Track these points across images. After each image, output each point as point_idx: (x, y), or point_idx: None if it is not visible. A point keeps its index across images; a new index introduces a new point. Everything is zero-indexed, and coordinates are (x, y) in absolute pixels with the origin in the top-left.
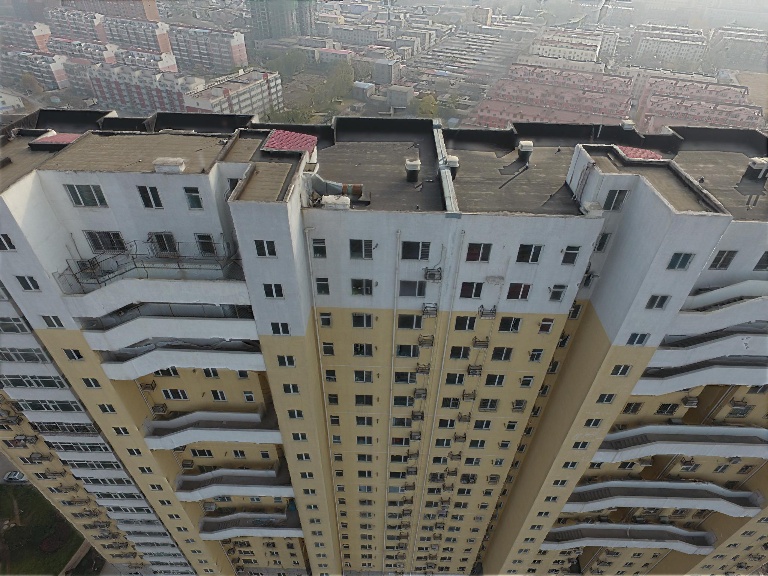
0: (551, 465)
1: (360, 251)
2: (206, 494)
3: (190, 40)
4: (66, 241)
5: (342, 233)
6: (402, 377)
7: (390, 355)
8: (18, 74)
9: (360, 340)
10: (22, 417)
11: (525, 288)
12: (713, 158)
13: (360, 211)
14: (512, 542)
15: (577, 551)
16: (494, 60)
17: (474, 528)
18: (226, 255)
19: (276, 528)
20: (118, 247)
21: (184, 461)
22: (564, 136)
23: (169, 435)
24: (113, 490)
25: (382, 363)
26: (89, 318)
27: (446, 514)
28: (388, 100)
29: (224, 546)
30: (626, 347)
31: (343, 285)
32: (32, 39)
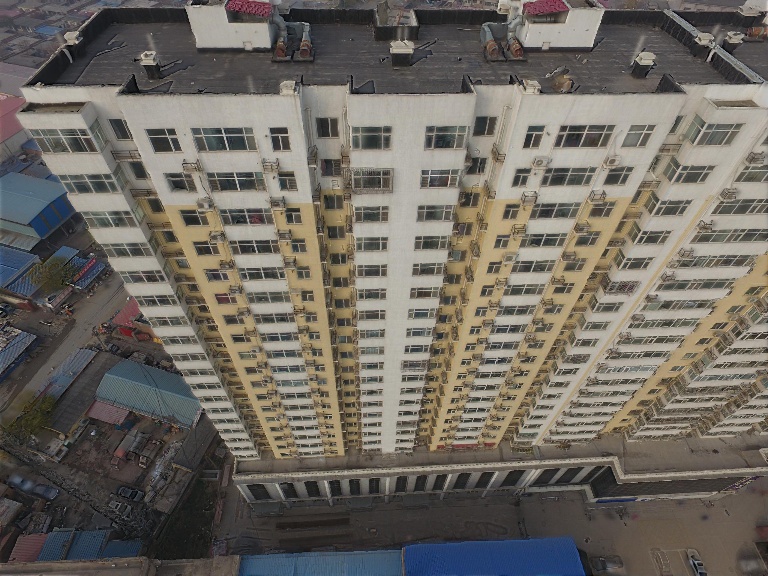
0: None
1: None
2: None
3: None
4: None
5: None
6: None
7: None
8: None
9: None
10: None
11: None
12: (422, 88)
13: None
14: None
15: None
16: None
17: None
18: None
19: None
20: None
21: None
22: None
23: None
24: None
25: None
26: None
27: None
28: None
29: None
30: None
31: None
32: None
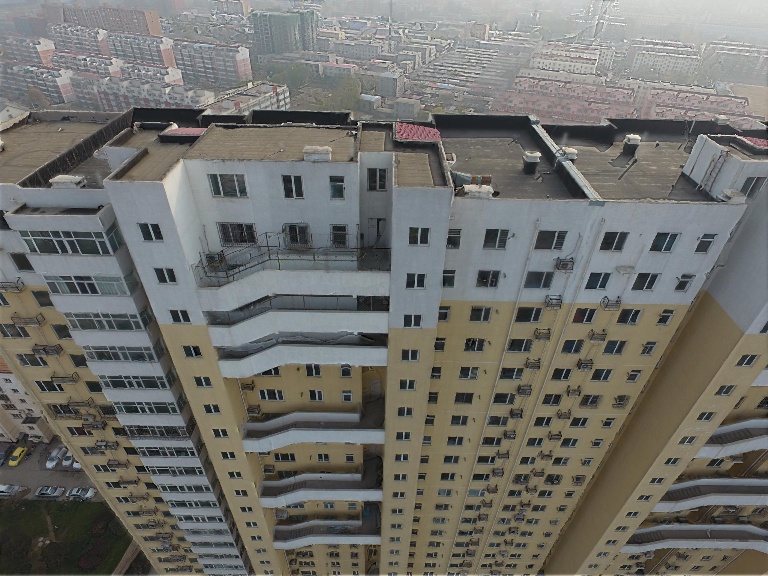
0: (653, 462)
1: (494, 241)
2: (291, 499)
3: (195, 55)
4: (199, 233)
5: (480, 222)
6: (508, 373)
7: (501, 350)
8: (23, 88)
9: (474, 335)
10: (108, 421)
11: (652, 278)
12: None
13: (504, 199)
14: (593, 545)
15: (648, 555)
16: (495, 74)
17: (547, 532)
18: (358, 247)
19: (354, 535)
20: (249, 239)
21: (265, 466)
22: (656, 132)
23: (269, 436)
24: (189, 498)
25: (491, 359)
26: (217, 312)
27: (523, 518)
28: (395, 112)
29: (287, 557)
30: (758, 336)
31: (470, 277)
32: (36, 54)
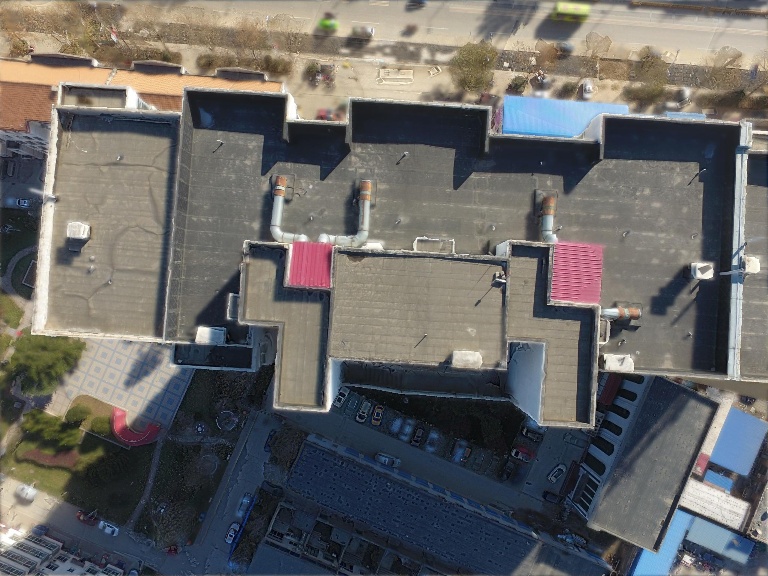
0: None
1: None
2: None
3: None
4: None
5: None
6: None
7: None
8: None
9: None
10: None
11: None
12: None
13: None
14: None
15: None
16: None
17: None
18: None
19: None
20: None
21: None
22: None
23: None
24: None
25: None
26: None
27: None
28: None
29: None
30: None
31: None
32: None
